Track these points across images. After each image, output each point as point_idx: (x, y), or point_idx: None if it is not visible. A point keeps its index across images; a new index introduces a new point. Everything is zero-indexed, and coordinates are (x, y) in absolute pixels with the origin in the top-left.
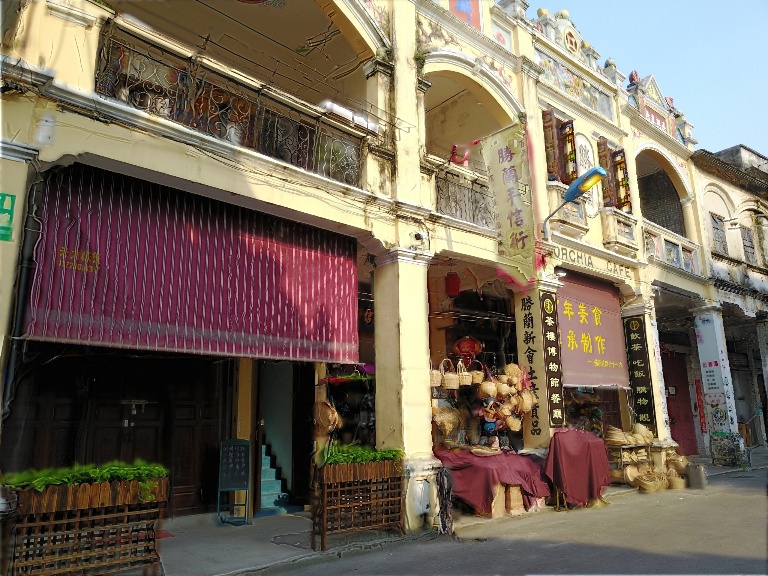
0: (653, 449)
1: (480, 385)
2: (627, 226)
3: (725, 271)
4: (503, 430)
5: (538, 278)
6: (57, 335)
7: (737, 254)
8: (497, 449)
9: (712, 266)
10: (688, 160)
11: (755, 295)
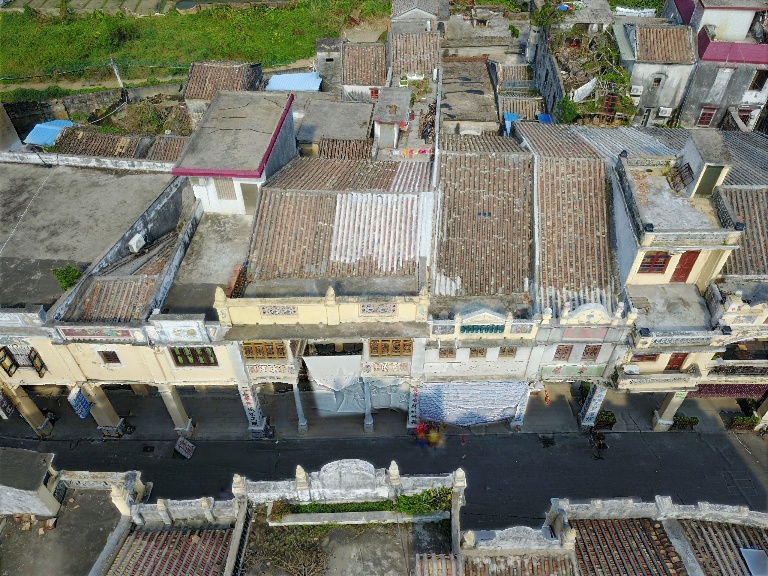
0: None
1: None
2: None
3: None
4: None
5: None
6: (686, 396)
7: None
8: None
9: None
10: None
11: None
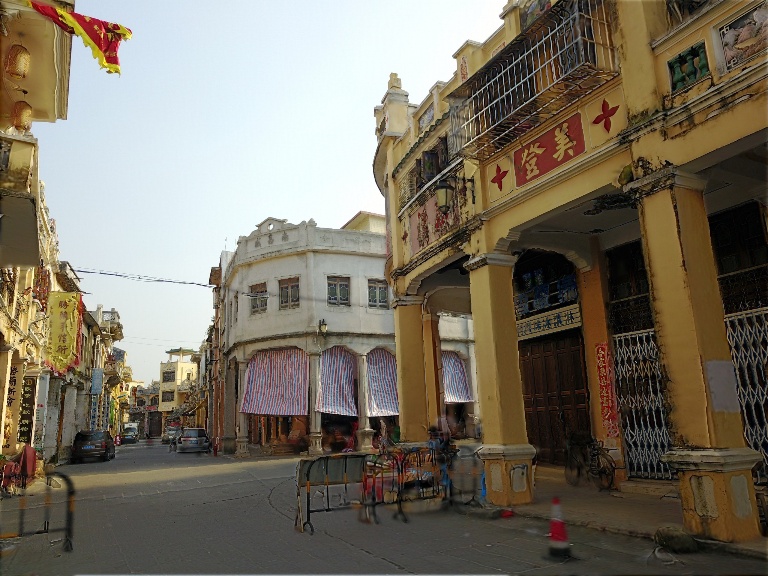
0: None
1: None
2: None
3: None
4: None
5: (27, 358)
6: None
7: None
8: None
9: None
10: (55, 274)
11: None
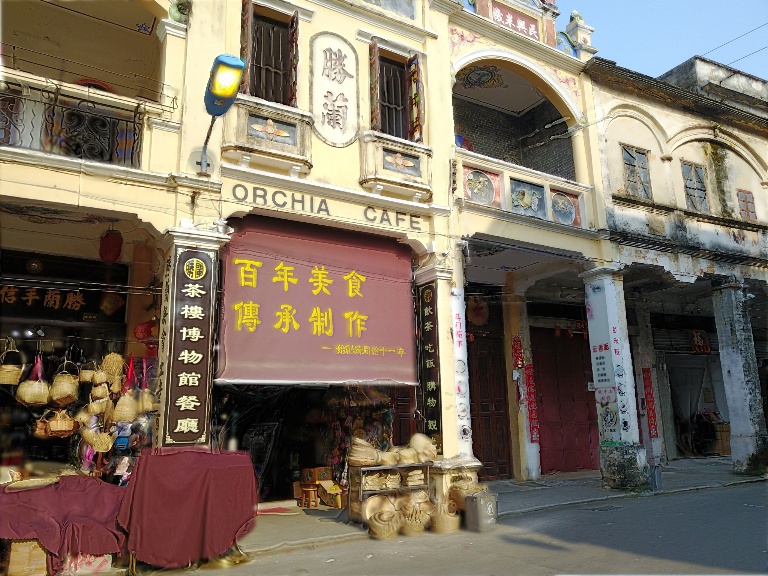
0: (434, 470)
1: (17, 386)
2: (411, 158)
3: (641, 221)
4: (137, 448)
5: None
6: None
7: (669, 199)
8: (121, 475)
9: (612, 214)
10: (580, 74)
11: (697, 253)
